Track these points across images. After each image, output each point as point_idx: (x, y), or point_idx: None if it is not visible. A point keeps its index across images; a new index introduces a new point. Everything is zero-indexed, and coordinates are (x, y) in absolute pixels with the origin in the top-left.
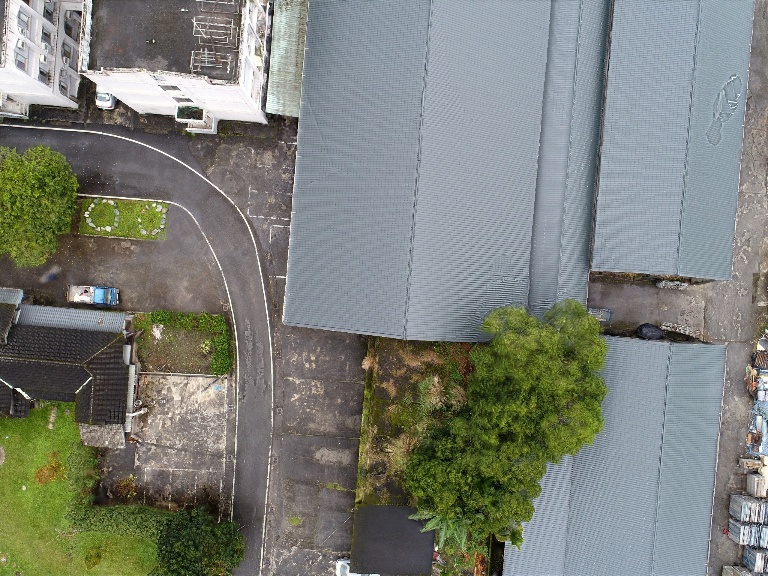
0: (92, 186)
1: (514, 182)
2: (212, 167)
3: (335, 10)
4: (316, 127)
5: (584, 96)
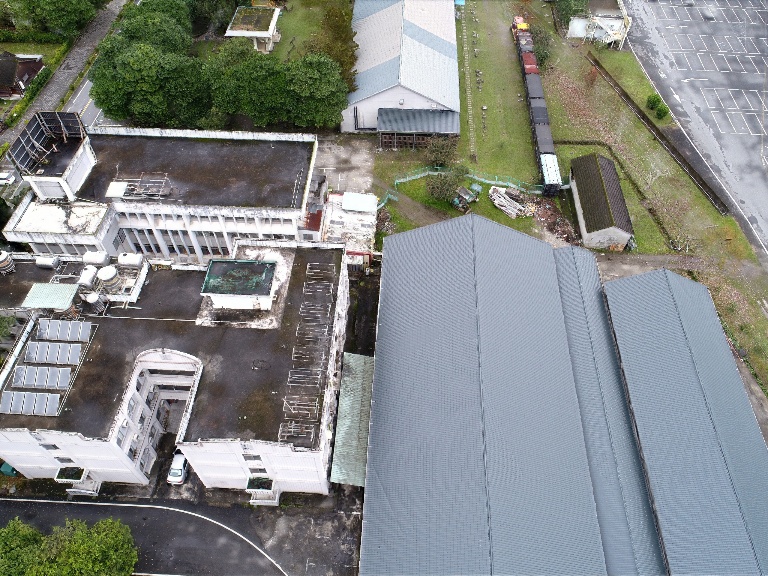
0: (145, 563)
1: (581, 541)
2: (271, 539)
3: (396, 392)
4: (382, 492)
5: (624, 458)
